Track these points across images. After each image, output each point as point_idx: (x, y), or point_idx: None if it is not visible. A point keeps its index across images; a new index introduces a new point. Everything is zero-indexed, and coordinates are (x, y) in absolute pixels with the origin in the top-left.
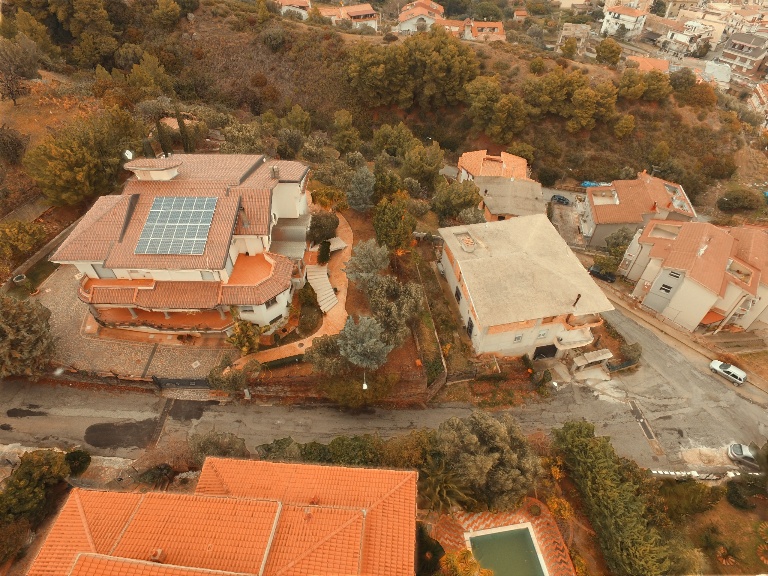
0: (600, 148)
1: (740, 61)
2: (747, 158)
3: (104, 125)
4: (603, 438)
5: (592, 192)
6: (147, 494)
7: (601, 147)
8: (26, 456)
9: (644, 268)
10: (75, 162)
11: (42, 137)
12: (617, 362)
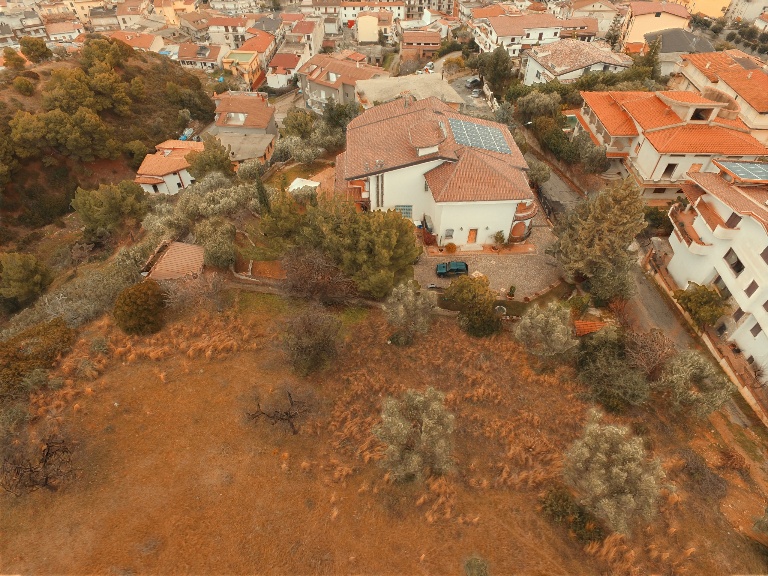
0: (148, 115)
1: (3, 42)
2: (186, 70)
3: None
4: (515, 86)
5: (223, 124)
6: (646, 129)
7: (148, 113)
8: (645, 210)
9: (354, 96)
10: None
11: None
12: None
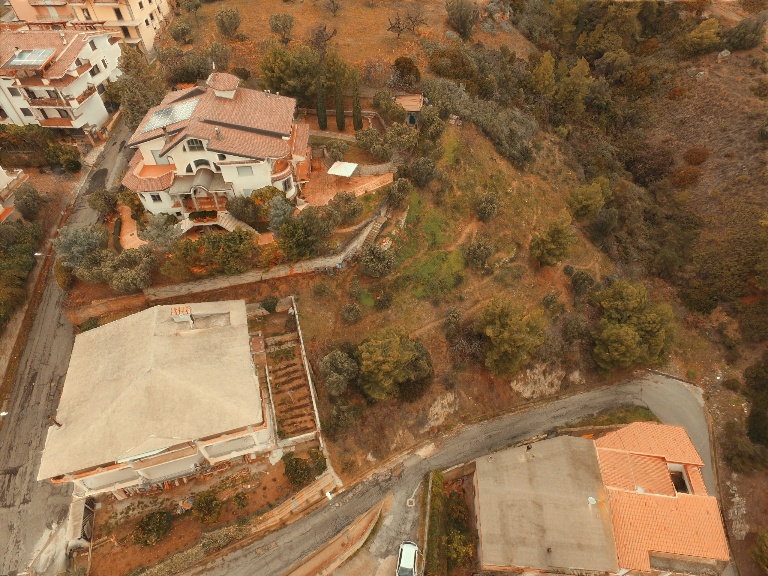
0: None
1: None
2: None
3: (315, 60)
4: None
5: None
6: None
7: None
8: None
9: None
10: (271, 68)
11: (275, 44)
12: (85, 570)
